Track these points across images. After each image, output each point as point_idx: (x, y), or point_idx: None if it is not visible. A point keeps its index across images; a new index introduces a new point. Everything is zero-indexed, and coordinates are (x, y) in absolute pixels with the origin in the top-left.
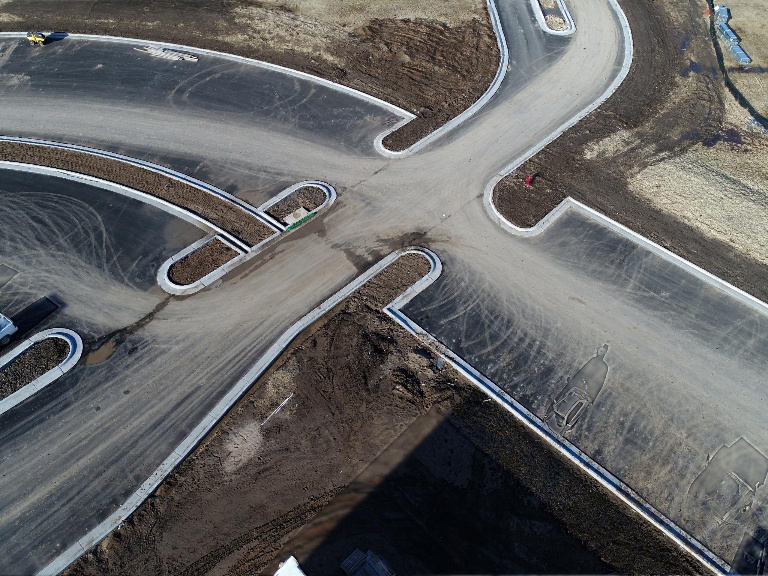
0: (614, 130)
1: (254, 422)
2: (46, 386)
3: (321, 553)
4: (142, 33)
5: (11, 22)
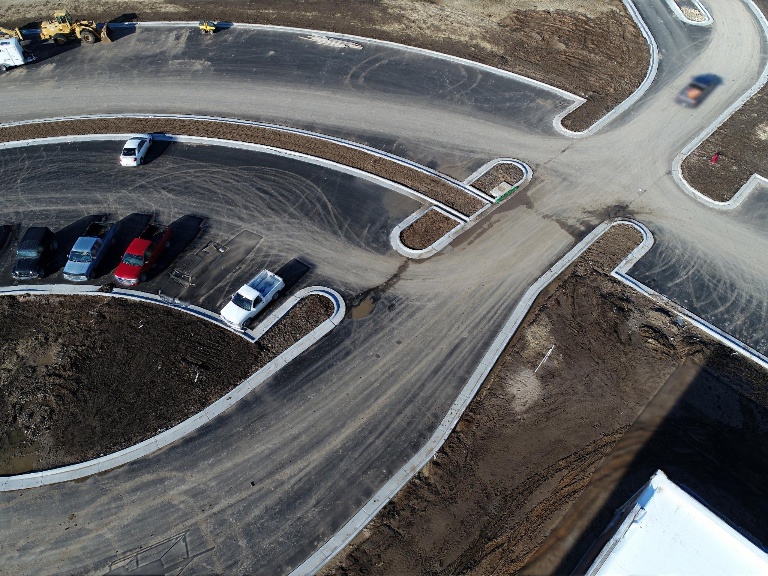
0: None
1: (527, 369)
2: (323, 336)
3: (628, 481)
4: (303, 22)
5: (177, 12)
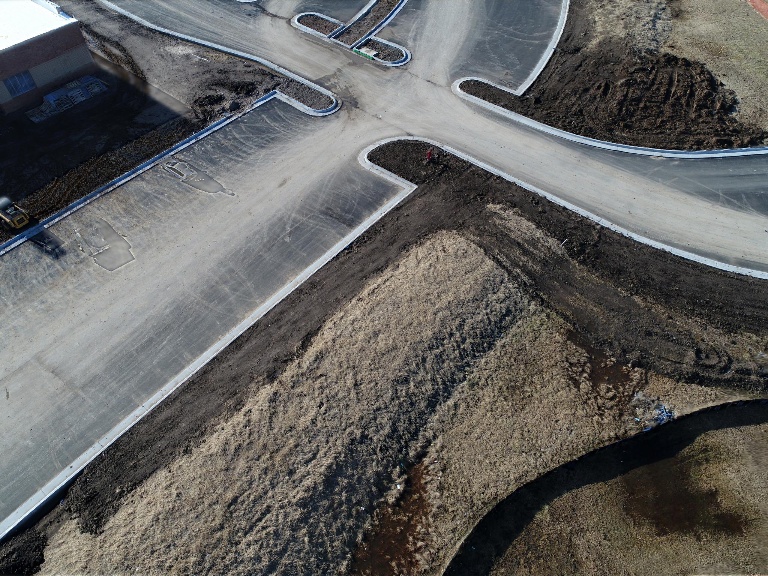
0: (557, 235)
1: (193, 52)
2: None
3: (112, 76)
4: None
5: None
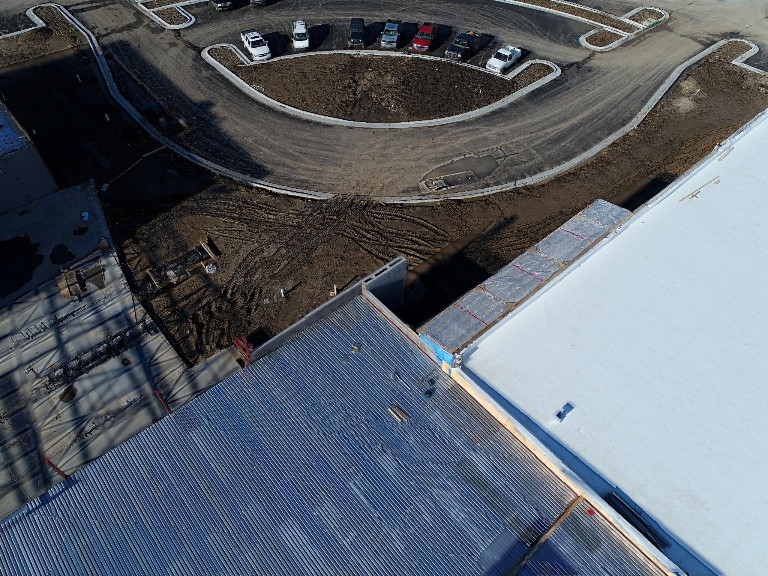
0: None
1: (685, 97)
2: (551, 81)
3: None
4: None
5: None
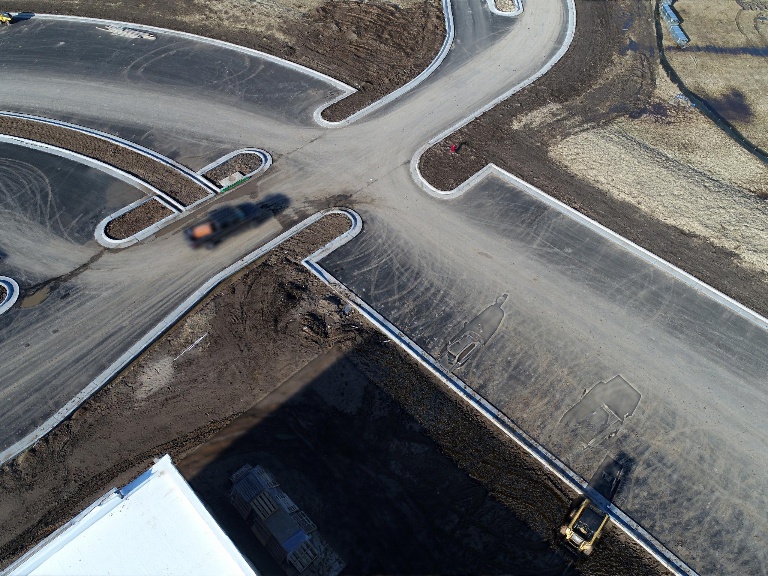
0: (544, 103)
1: (168, 357)
2: None
3: (214, 467)
4: (105, 13)
5: None
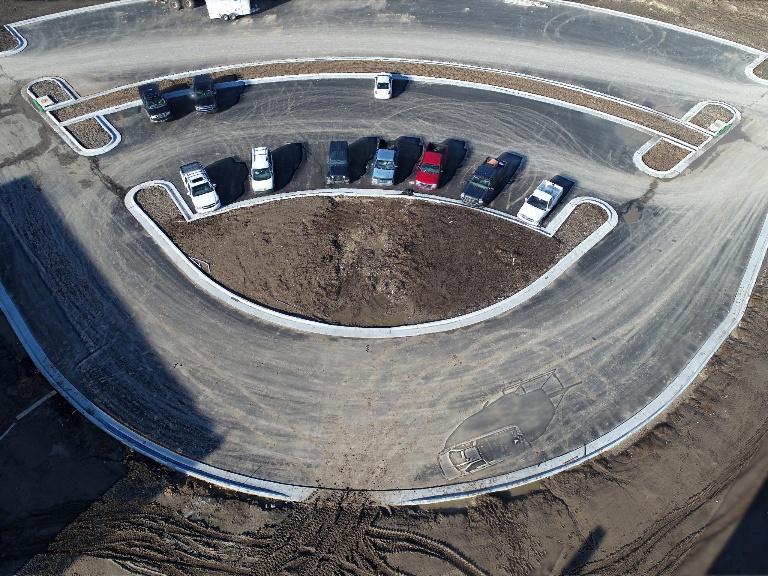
0: None
1: None
2: (607, 235)
3: None
4: None
5: None
